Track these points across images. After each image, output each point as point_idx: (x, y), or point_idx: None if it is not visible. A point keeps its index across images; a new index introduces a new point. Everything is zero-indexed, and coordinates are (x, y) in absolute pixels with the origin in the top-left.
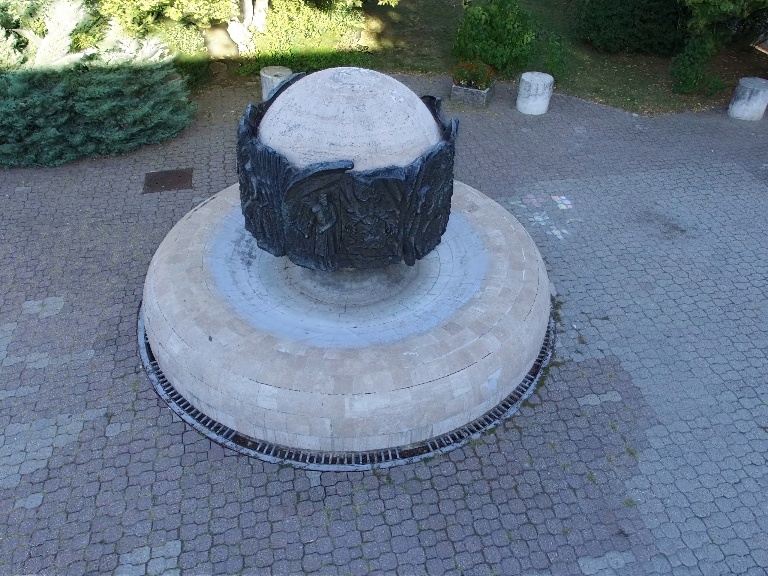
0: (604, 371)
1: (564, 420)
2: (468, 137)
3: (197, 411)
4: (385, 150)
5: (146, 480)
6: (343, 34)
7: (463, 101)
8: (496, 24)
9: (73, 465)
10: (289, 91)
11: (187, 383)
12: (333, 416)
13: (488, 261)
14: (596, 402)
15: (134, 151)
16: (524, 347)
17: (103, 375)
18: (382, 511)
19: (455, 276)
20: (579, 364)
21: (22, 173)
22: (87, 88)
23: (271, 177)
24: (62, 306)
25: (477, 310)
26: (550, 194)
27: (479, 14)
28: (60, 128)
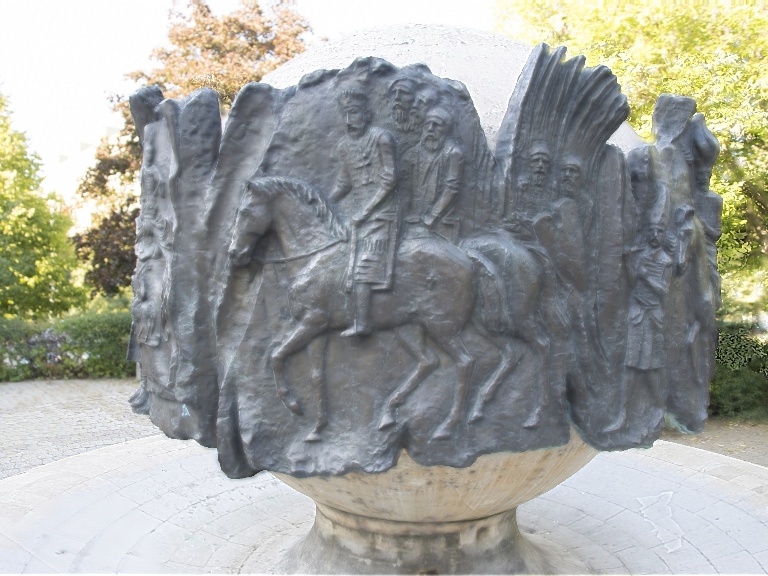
0: None
1: None
2: None
3: None
4: None
5: None
6: None
7: None
8: None
9: None
10: None
11: None
12: None
13: None
14: None
15: None
16: None
17: None
18: None
19: None
20: None
21: None
22: None
23: None
24: None
25: None
26: None
27: None
28: None
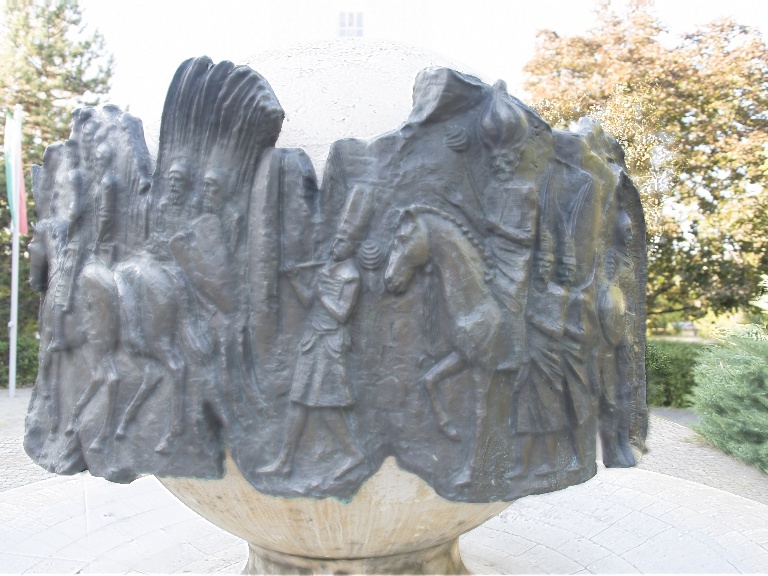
0: None
1: None
2: None
3: None
4: None
5: None
6: None
7: None
8: None
9: None
10: None
11: None
12: None
13: None
14: None
15: None
16: None
17: None
18: None
19: None
20: None
21: (743, 471)
22: None
23: None
24: None
25: None
26: None
27: None
28: None
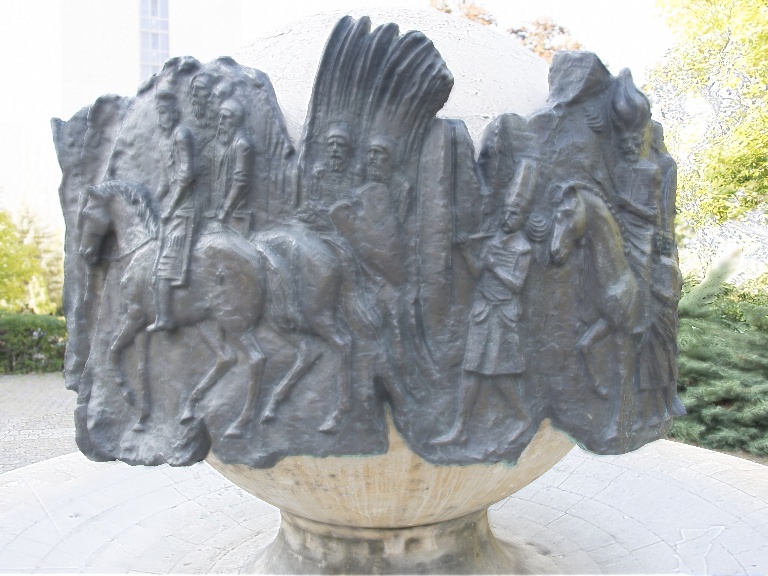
0: None
1: None
2: None
3: None
4: None
5: None
6: None
7: None
8: None
9: None
10: None
11: None
12: None
13: None
14: None
15: (717, 450)
16: None
17: None
18: None
19: None
20: None
21: None
22: None
23: None
24: None
25: None
26: None
27: None
28: None
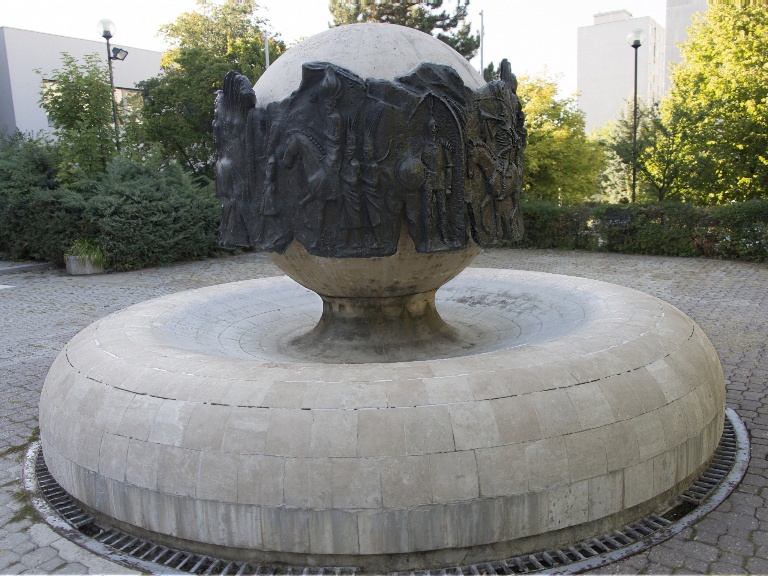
0: None
1: (1, 417)
2: None
3: None
4: None
5: None
6: None
7: None
8: None
9: None
10: None
11: None
12: None
13: None
14: None
15: None
16: None
17: None
18: None
19: None
20: None
21: None
22: None
23: None
24: None
25: (147, 314)
26: None
27: None
28: None
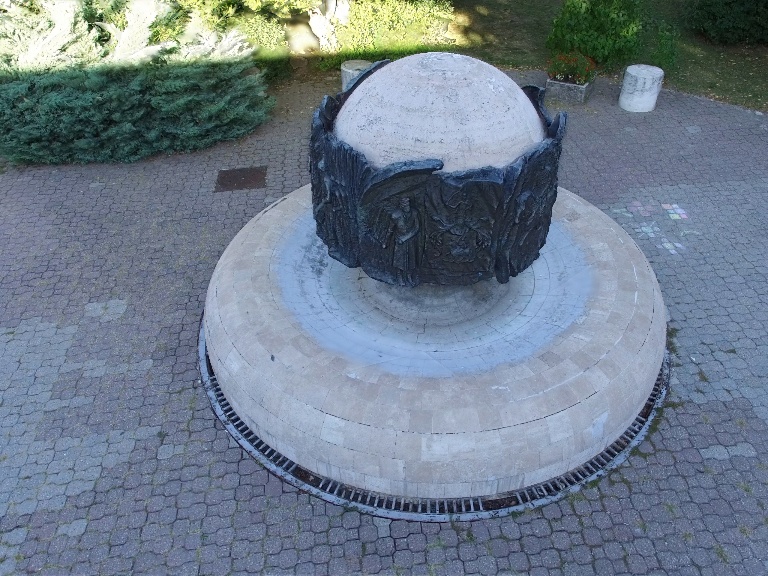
0: (732, 417)
1: (684, 476)
2: (564, 136)
3: (256, 436)
4: (480, 148)
5: (196, 514)
6: (429, 26)
7: (558, 97)
8: (598, 13)
9: (121, 490)
10: (370, 79)
11: (246, 406)
12: (407, 457)
13: (592, 279)
14: (724, 456)
15: (209, 148)
16: (637, 385)
17: (160, 389)
18: (461, 575)
19: (552, 295)
20: (701, 406)
21: (98, 169)
22: (164, 82)
23: (346, 177)
24: (124, 310)
25: (580, 338)
26: (660, 202)
27: (579, 2)
28: (136, 123)
